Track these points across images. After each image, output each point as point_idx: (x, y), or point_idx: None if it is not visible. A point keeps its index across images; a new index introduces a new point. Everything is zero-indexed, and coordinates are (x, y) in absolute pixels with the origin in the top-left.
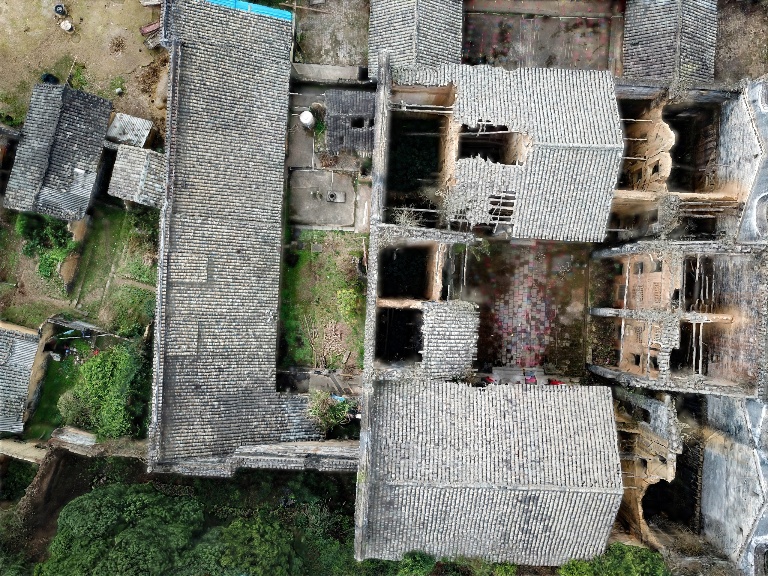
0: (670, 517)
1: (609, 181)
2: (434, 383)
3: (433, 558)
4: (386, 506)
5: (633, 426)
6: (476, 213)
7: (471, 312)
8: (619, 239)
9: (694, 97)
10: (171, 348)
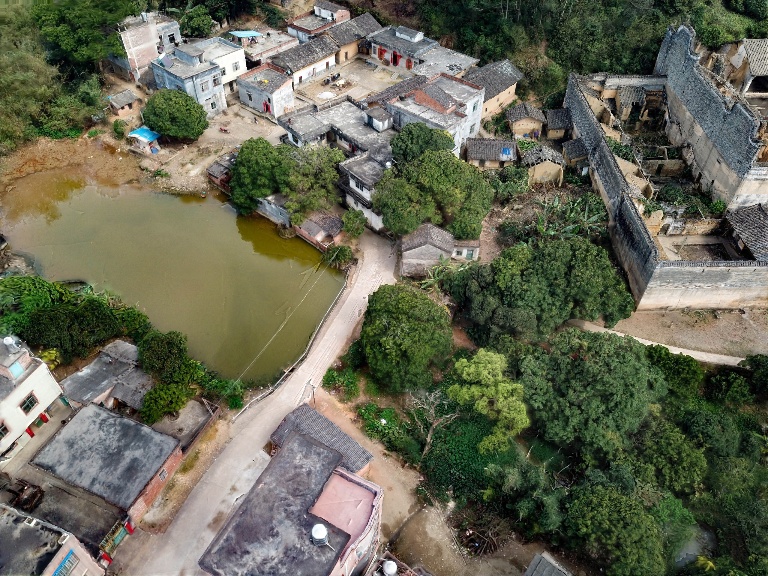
0: None
1: None
2: None
3: None
4: None
5: None
6: None
7: None
8: None
9: None
10: None
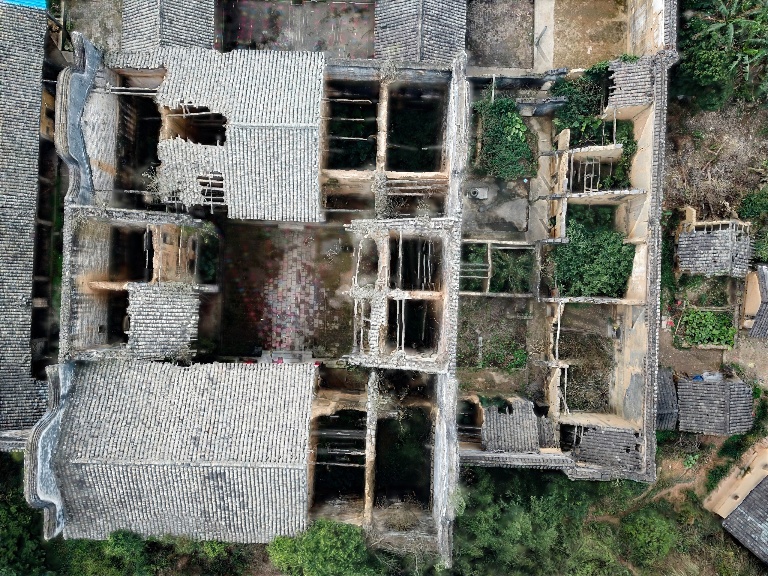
0: (417, 496)
1: (311, 160)
2: (139, 363)
3: (139, 537)
4: (79, 485)
5: (364, 405)
6: (188, 194)
7: (187, 293)
8: None
9: (417, 77)
10: None
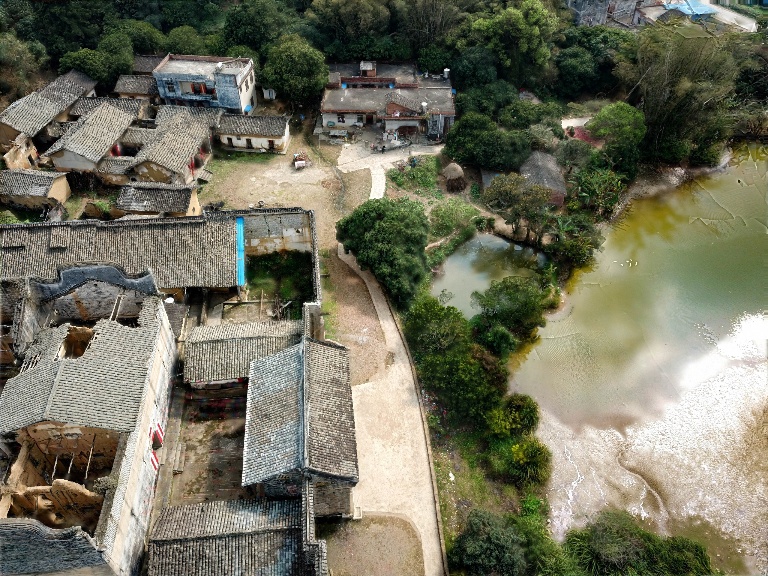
0: None
1: None
2: None
3: None
4: None
5: None
6: None
7: None
8: None
9: None
10: (8, 232)
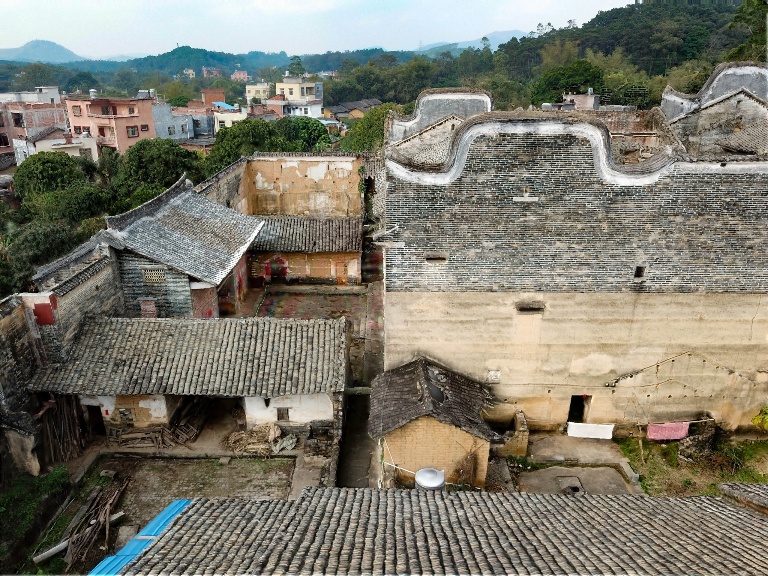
0: None
1: None
2: None
3: None
4: None
5: None
6: None
7: None
8: None
9: None
10: None
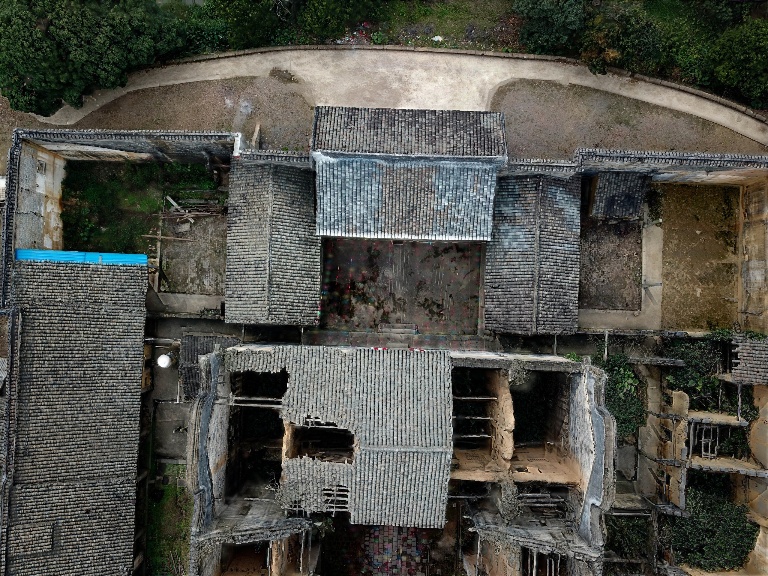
0: None
1: (442, 478)
2: None
3: None
4: None
5: None
6: (311, 503)
7: None
8: (484, 484)
9: None
10: None
